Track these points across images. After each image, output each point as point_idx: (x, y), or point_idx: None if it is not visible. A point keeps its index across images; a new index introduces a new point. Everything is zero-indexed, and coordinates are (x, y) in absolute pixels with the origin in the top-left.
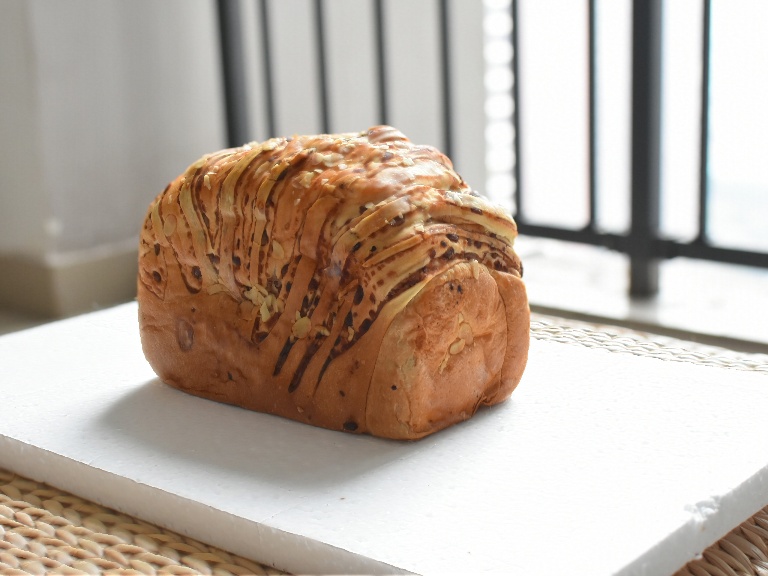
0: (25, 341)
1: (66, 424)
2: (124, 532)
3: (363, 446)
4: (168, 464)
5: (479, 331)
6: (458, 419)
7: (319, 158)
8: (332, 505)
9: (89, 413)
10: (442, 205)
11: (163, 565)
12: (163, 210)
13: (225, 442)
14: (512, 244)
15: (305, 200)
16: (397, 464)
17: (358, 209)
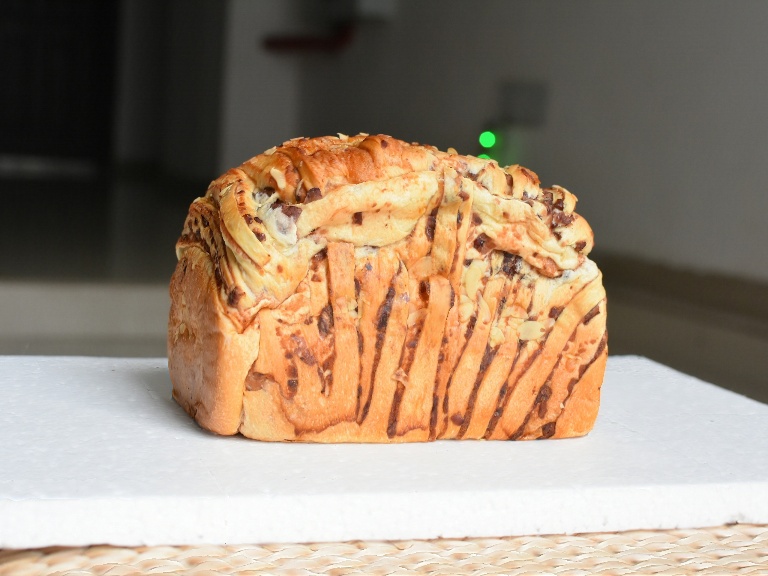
0: None
1: None
2: None
3: None
4: None
5: None
6: None
7: None
8: None
9: None
10: None
11: None
12: None
13: None
14: (241, 264)
15: None
16: (141, 387)
17: None
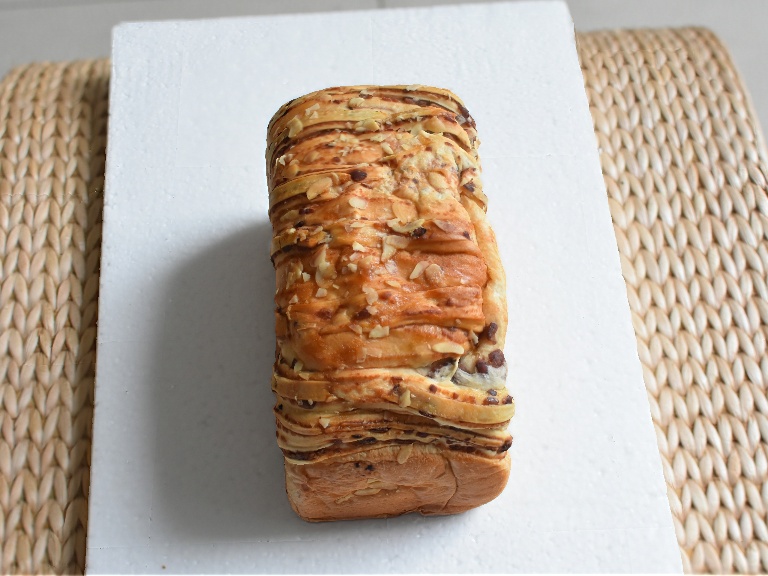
0: (291, 40)
1: (151, 257)
2: (78, 430)
3: (273, 491)
4: (136, 396)
5: (407, 485)
6: (374, 517)
7: (318, 260)
8: (148, 570)
9: (185, 247)
10: (375, 402)
11: (56, 499)
12: (269, 136)
13: (204, 391)
14: (500, 427)
15: (279, 298)
16: (255, 547)
17: (293, 358)
